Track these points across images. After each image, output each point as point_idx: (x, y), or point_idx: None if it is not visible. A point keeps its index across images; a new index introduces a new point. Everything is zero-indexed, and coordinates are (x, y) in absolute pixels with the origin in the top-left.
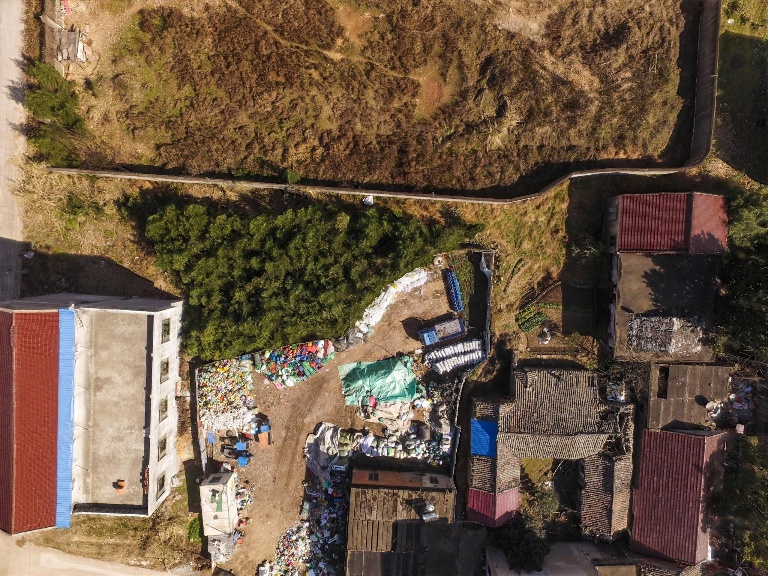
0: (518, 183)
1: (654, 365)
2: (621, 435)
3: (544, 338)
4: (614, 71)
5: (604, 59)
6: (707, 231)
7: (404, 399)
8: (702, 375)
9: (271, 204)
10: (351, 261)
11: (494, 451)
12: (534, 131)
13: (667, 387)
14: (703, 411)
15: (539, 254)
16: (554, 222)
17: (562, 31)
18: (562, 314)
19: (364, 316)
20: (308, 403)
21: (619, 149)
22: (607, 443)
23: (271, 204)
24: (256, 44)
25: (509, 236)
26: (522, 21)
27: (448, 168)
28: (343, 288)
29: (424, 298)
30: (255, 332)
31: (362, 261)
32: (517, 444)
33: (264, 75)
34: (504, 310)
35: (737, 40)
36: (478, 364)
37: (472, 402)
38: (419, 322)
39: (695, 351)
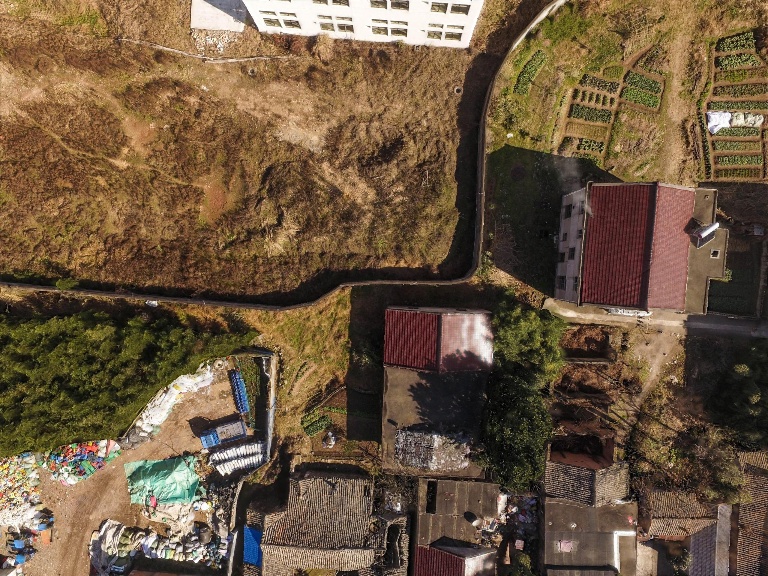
0: (299, 289)
1: (422, 480)
2: (396, 547)
3: (327, 443)
4: (387, 185)
5: (377, 173)
6: (465, 350)
7: (183, 501)
8: (471, 491)
9: (56, 304)
10: (118, 367)
11: (261, 562)
12: (312, 240)
13: (436, 502)
14: (473, 528)
15: (322, 359)
16: (337, 328)
17: (340, 144)
18: (347, 419)
19: (145, 417)
20: (94, 500)
21: (399, 258)
22: (388, 553)
23: (56, 304)
24: (44, 152)
25: (292, 340)
26: (302, 133)
27: (229, 273)
28: (104, 396)
29: (211, 398)
30: (17, 437)
31: (126, 369)
32: (285, 555)
33: (50, 181)
34: (288, 413)
35: (517, 154)
36: (256, 469)
37: (249, 507)
38: (206, 422)
39: (462, 467)
